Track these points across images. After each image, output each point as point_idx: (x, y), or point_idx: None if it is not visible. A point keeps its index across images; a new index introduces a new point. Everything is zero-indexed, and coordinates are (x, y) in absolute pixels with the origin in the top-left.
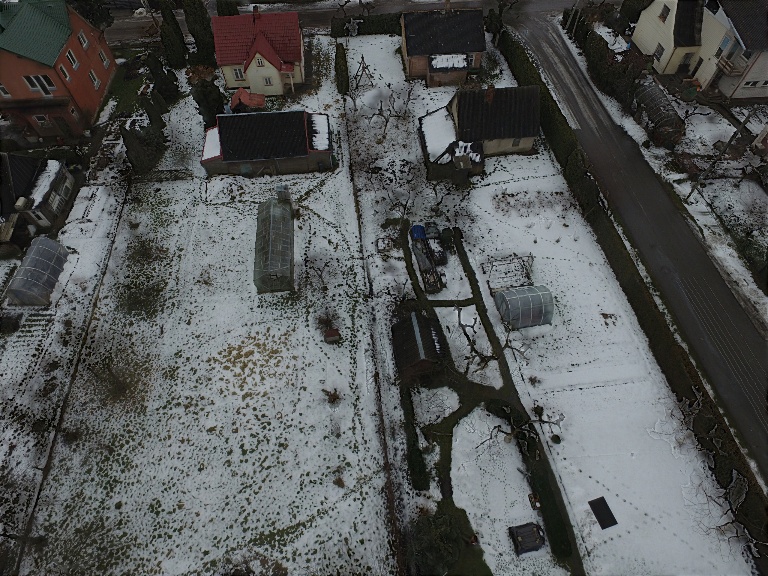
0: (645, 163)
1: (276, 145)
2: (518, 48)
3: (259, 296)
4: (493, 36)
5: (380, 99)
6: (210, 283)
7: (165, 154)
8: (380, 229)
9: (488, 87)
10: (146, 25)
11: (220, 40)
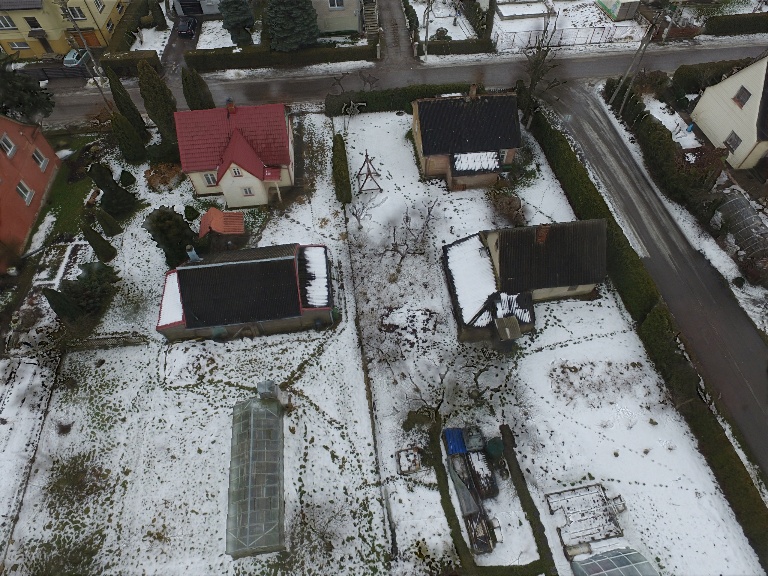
0: (742, 312)
1: (258, 304)
2: (561, 142)
3: (235, 563)
4: (524, 116)
5: (390, 210)
6: (165, 537)
7: (113, 301)
8: (401, 432)
9: (541, 227)
10: (100, 100)
11: (185, 141)
